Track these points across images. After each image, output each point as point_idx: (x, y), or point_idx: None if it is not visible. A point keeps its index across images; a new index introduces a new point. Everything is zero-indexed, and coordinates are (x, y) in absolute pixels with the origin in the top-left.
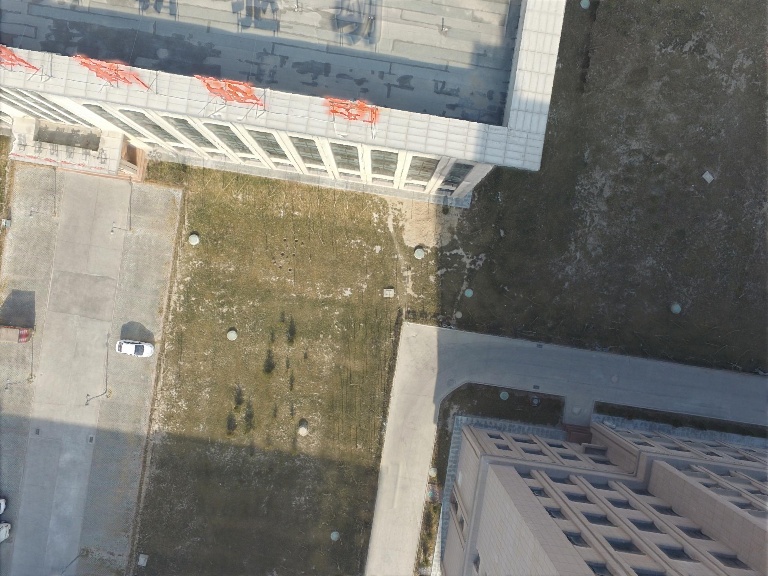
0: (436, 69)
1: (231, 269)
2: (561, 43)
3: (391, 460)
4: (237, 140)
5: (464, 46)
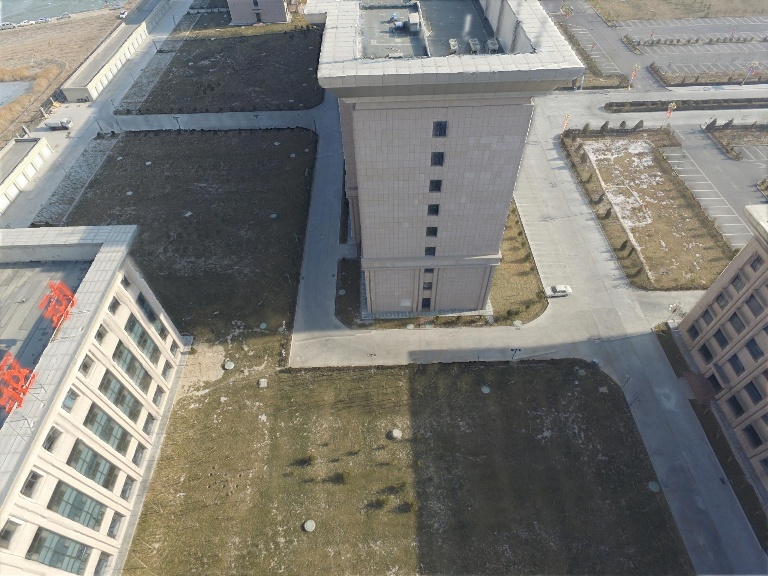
0: None
1: (237, 541)
2: None
3: (407, 358)
4: (81, 507)
5: (41, 288)
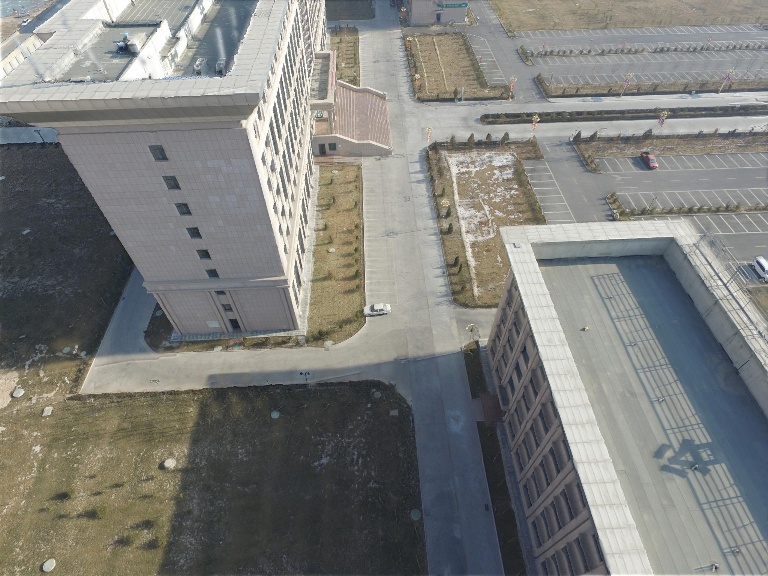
0: None
1: None
2: None
3: (205, 382)
4: None
5: None
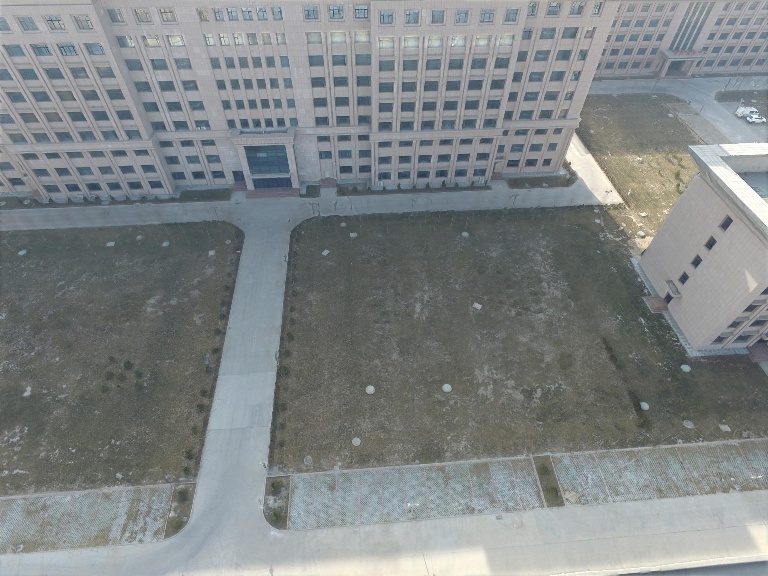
0: (767, 195)
1: None
2: (642, 372)
3: (586, 156)
4: None
5: None
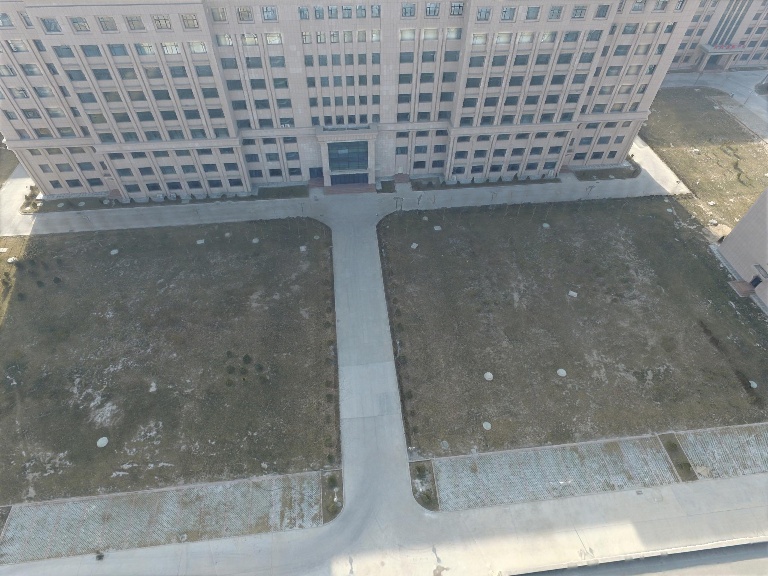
0: None
1: None
2: (742, 352)
3: (645, 148)
4: None
5: None
